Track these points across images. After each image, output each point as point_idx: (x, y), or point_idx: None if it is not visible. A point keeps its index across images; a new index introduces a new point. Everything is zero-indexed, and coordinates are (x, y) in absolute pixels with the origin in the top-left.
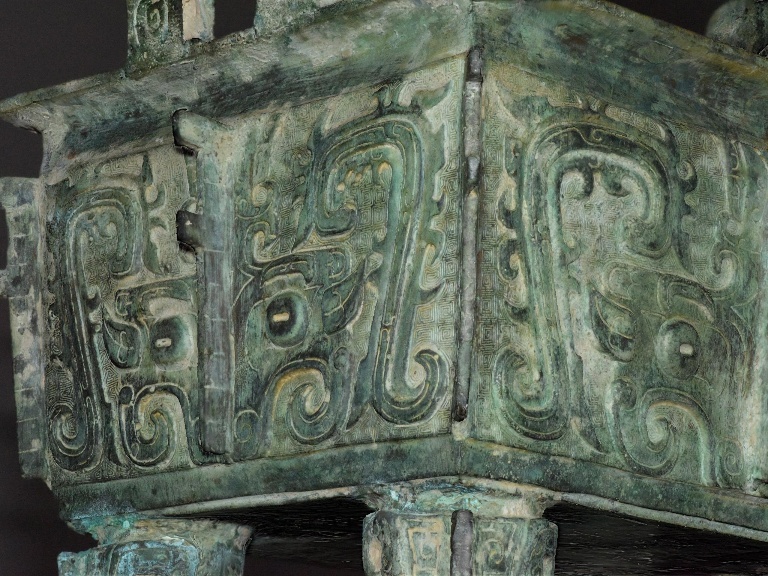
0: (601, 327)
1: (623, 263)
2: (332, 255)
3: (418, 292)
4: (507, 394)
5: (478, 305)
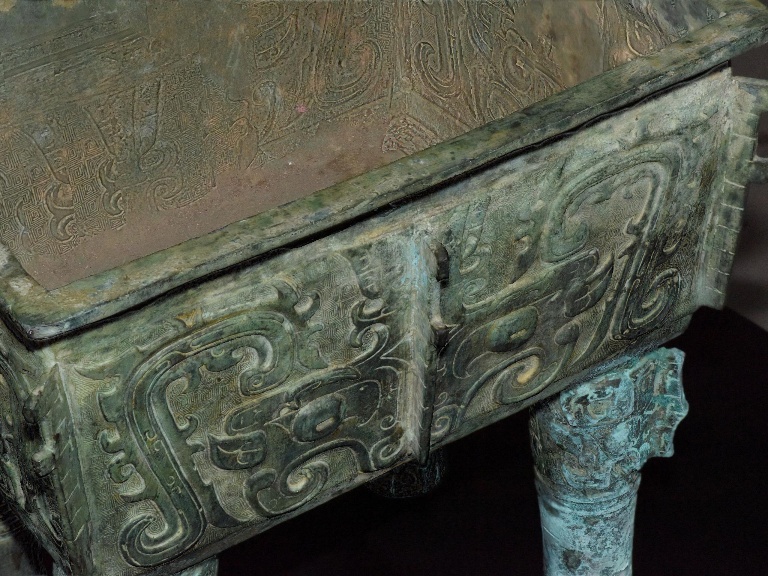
0: (287, 41)
1: (266, 0)
2: (490, 7)
3: (435, 7)
4: (371, 67)
5: (394, 8)
